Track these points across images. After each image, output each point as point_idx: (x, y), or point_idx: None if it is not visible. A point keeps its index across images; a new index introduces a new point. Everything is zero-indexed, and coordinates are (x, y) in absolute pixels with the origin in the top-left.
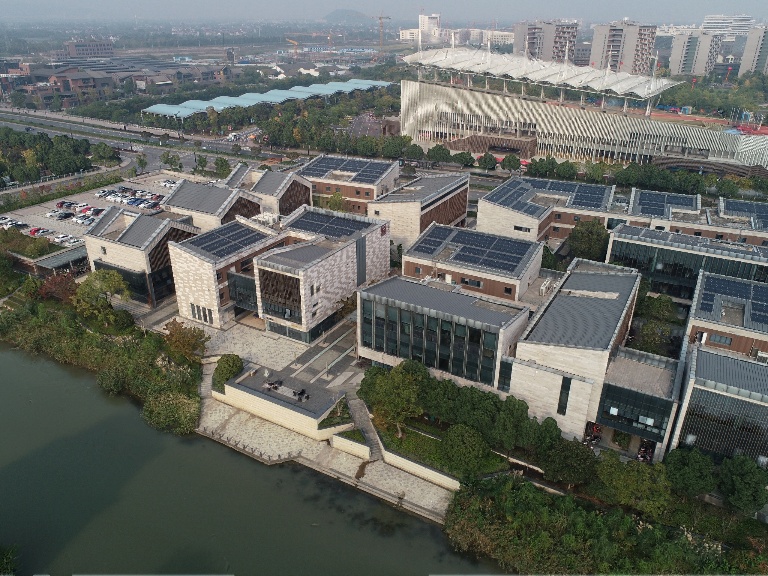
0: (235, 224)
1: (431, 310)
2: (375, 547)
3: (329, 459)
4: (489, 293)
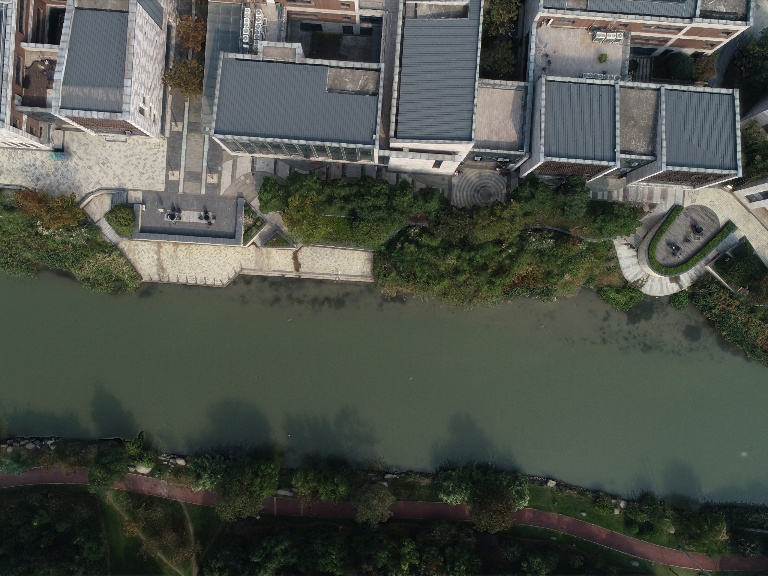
0: None
1: (300, 142)
2: (337, 319)
3: (266, 262)
4: (324, 8)
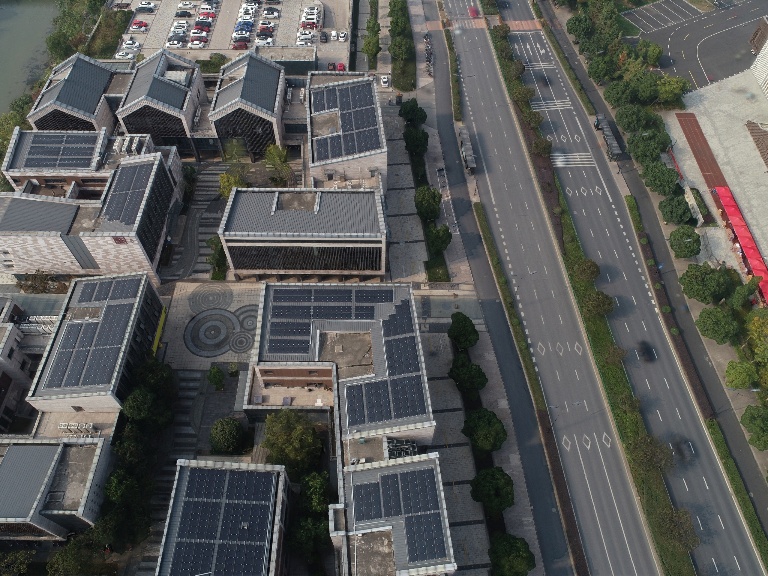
0: (94, 136)
1: None
2: None
3: None
4: None
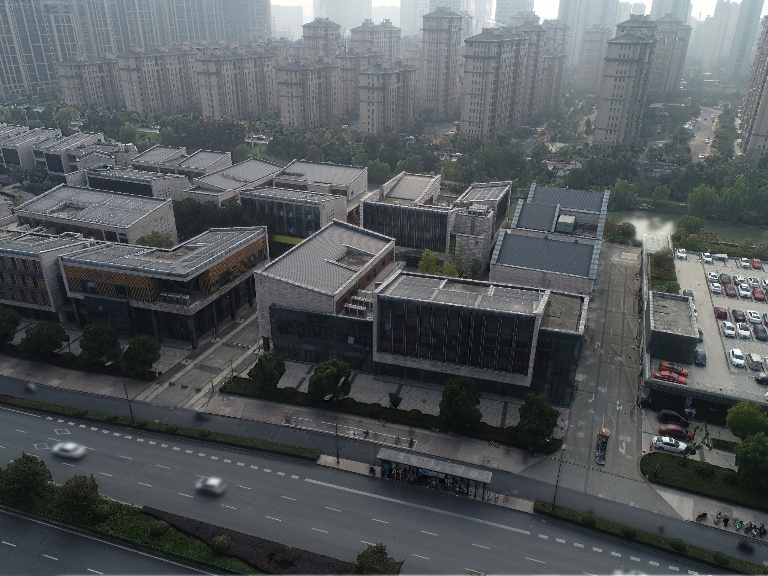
0: None
1: None
2: None
3: None
4: None
